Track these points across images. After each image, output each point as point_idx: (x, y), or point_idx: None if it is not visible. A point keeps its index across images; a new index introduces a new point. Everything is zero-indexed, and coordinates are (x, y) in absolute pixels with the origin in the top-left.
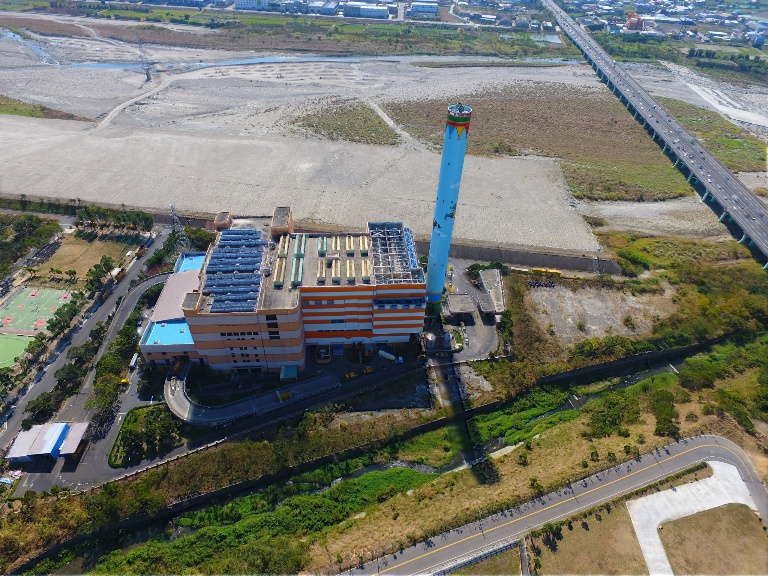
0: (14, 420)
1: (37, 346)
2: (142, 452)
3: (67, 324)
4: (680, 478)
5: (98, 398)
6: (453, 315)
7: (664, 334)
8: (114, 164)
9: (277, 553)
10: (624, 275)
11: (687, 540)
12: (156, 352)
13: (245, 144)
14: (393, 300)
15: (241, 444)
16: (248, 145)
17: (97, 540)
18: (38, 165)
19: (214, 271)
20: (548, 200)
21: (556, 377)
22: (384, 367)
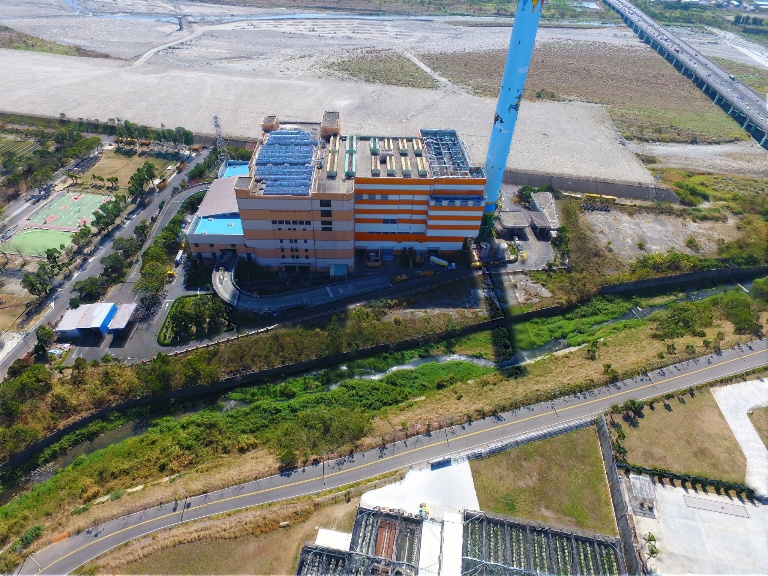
0: (61, 301)
1: (83, 235)
2: (191, 333)
3: (111, 220)
4: (767, 370)
5: (146, 280)
6: (506, 229)
7: (732, 254)
8: (150, 95)
9: (338, 420)
10: (683, 204)
11: None
12: (203, 243)
13: (281, 83)
14: (450, 197)
15: (292, 331)
16: (284, 84)
17: (149, 407)
18: (75, 94)
19: (264, 163)
20: (597, 138)
21: (618, 288)
22: (437, 271)
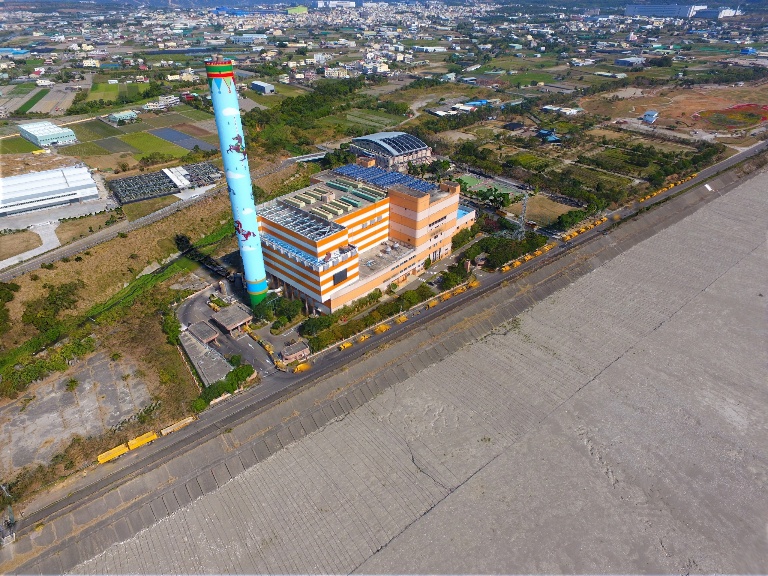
0: None
1: None
2: None
3: None
4: None
5: None
6: None
7: None
8: None
9: None
10: None
11: (24, 247)
12: None
13: None
14: None
15: None
16: None
17: None
18: None
19: None
20: None
21: None
22: None
